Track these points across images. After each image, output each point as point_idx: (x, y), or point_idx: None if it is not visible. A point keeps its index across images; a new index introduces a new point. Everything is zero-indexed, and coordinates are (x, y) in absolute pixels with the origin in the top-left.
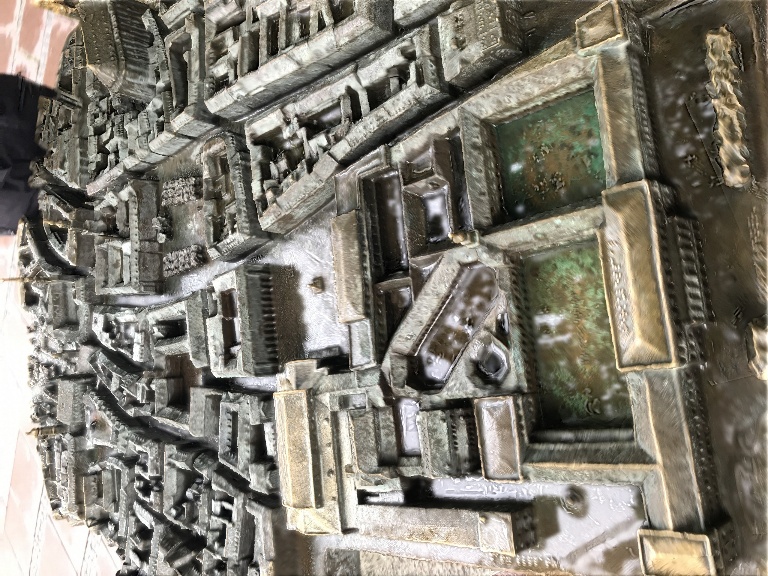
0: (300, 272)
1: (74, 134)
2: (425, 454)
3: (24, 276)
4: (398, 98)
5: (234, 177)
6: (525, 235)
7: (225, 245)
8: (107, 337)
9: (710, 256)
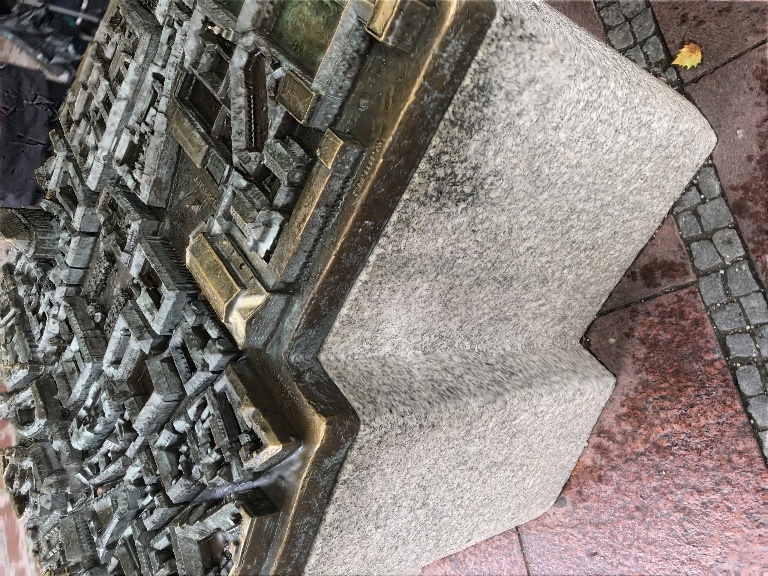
0: (185, 216)
1: (19, 332)
2: (277, 170)
3: (13, 496)
4: (176, 43)
5: (118, 198)
6: (252, 6)
7: (130, 245)
8: (82, 428)
9: None
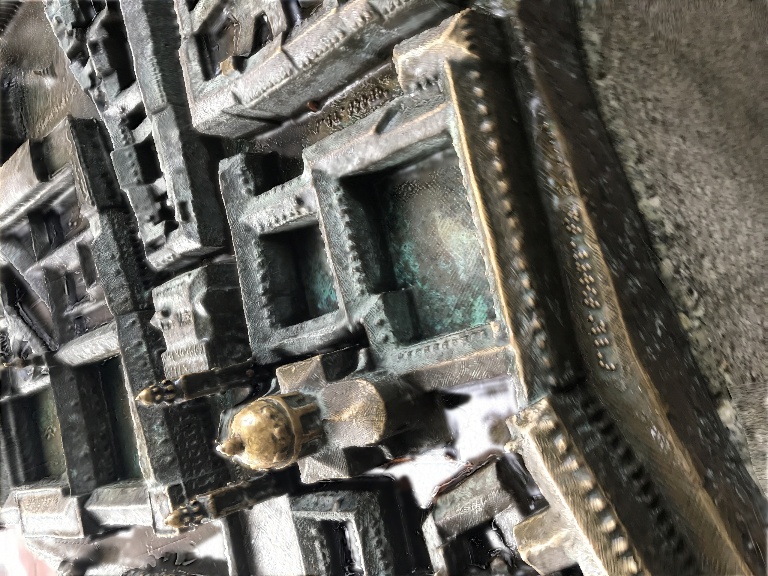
0: None
1: None
2: None
3: None
4: None
5: None
6: None
7: None
8: None
9: (118, 535)
